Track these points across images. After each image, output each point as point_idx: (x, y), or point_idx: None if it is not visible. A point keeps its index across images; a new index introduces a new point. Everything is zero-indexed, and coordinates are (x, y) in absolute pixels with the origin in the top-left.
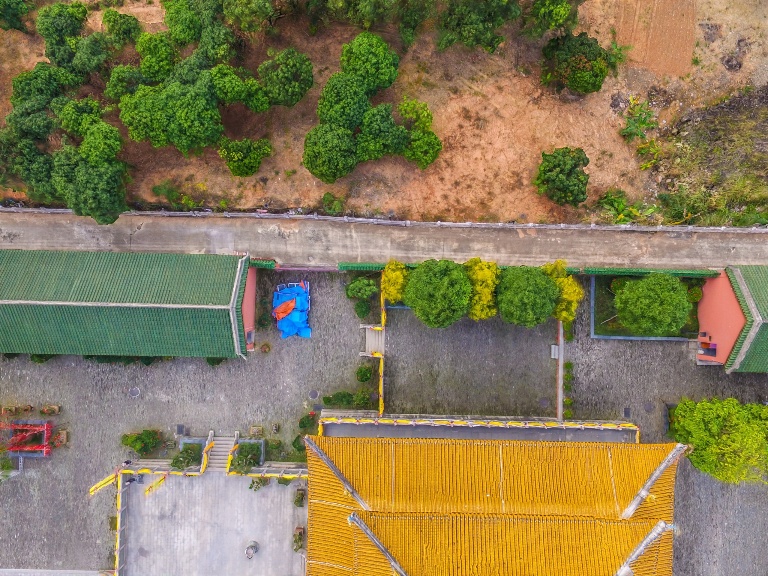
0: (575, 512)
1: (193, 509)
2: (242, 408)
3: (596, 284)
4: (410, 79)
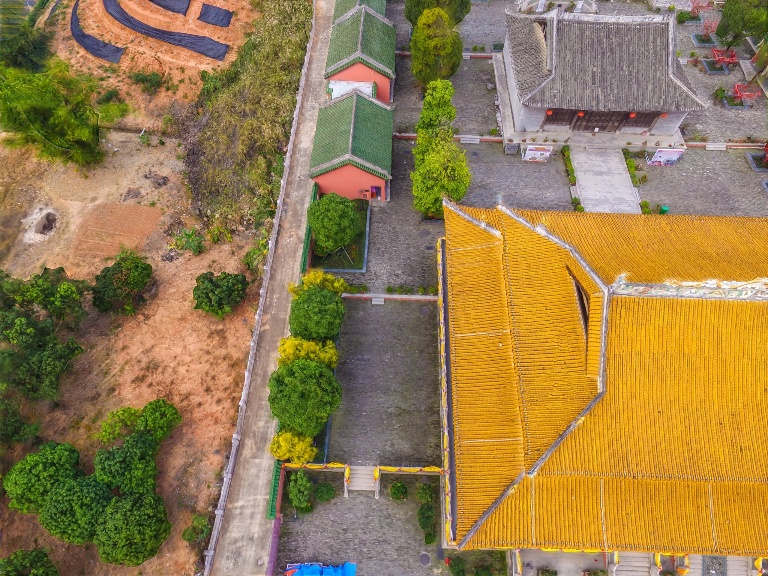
0: None
1: None
2: None
3: (318, 268)
4: (83, 437)
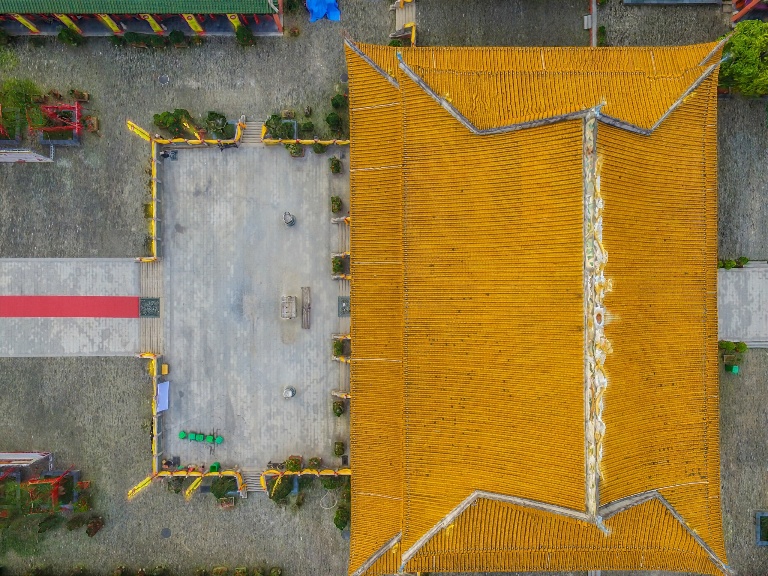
0: None
1: (228, 184)
2: (273, 93)
3: None
4: None
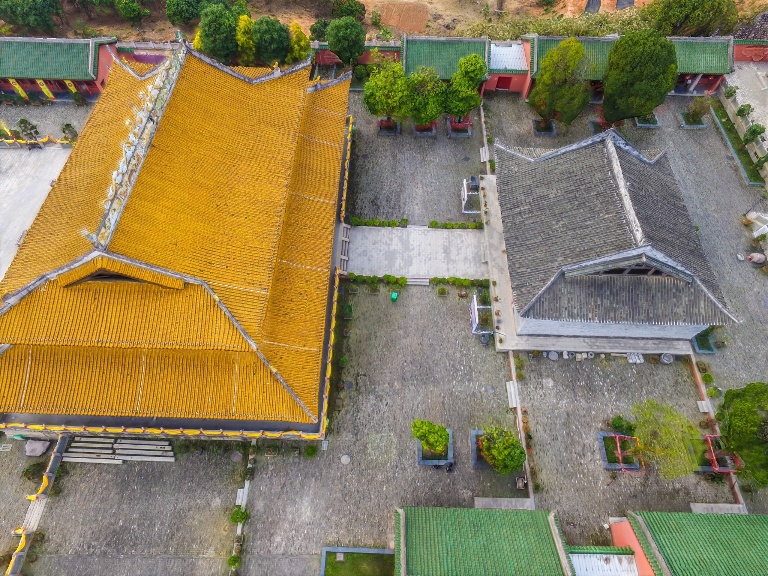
0: None
1: (24, 168)
2: None
3: (337, 67)
4: None
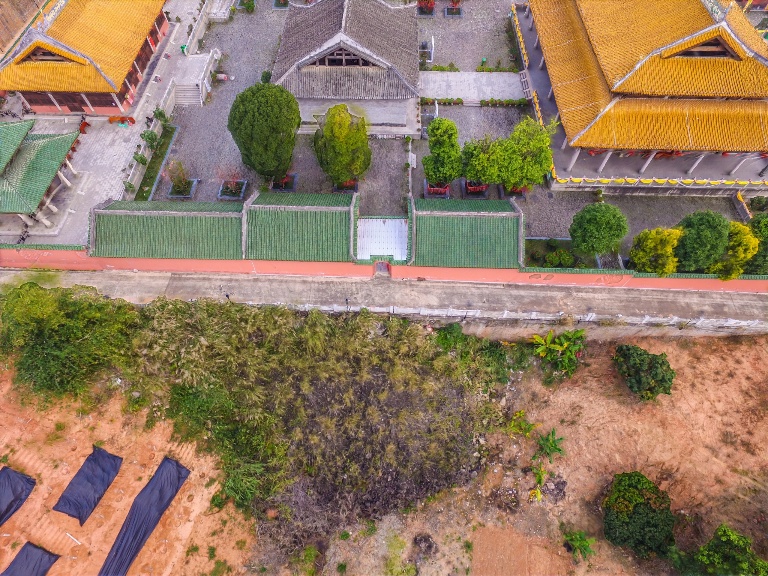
0: (640, 109)
1: None
2: None
3: None
4: None
